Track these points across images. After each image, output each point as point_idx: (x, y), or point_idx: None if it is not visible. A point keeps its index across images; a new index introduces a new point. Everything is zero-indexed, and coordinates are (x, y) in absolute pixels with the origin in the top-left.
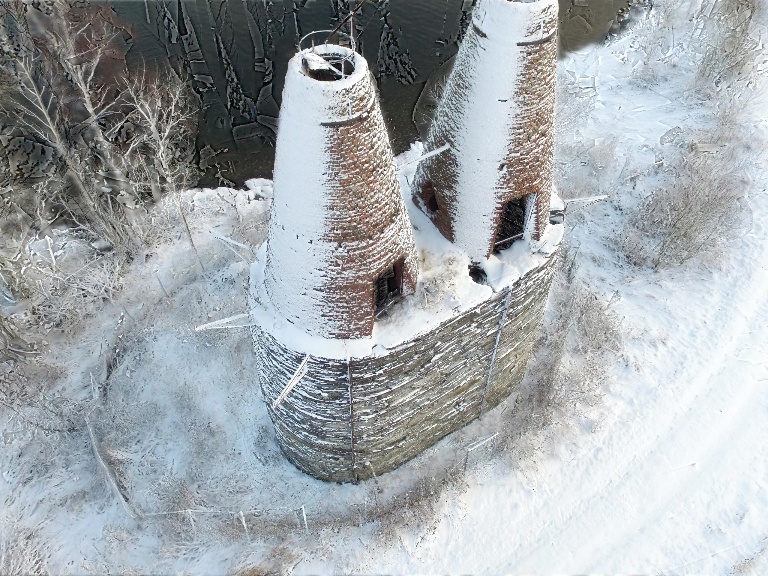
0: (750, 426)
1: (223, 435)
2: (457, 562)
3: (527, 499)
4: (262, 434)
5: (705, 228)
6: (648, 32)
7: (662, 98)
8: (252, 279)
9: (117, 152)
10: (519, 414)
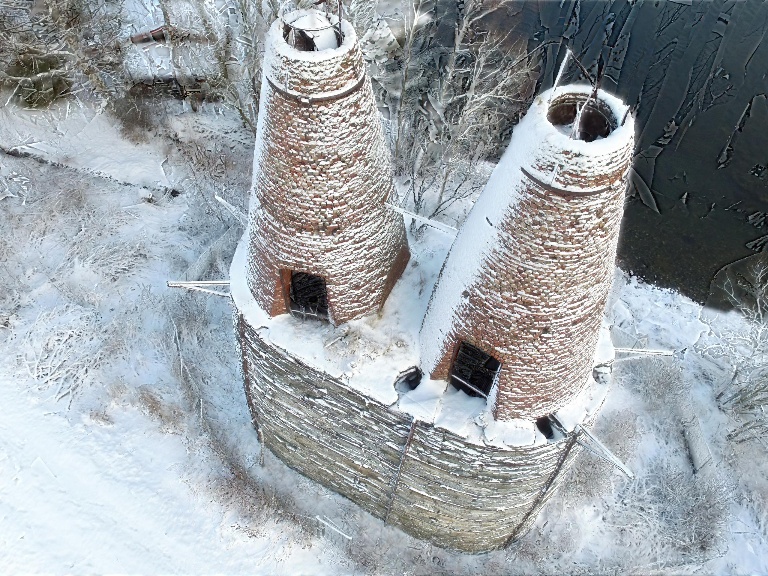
0: None
1: None
2: (235, 574)
3: None
4: None
5: None
6: None
7: None
8: None
9: (455, 90)
10: (420, 567)
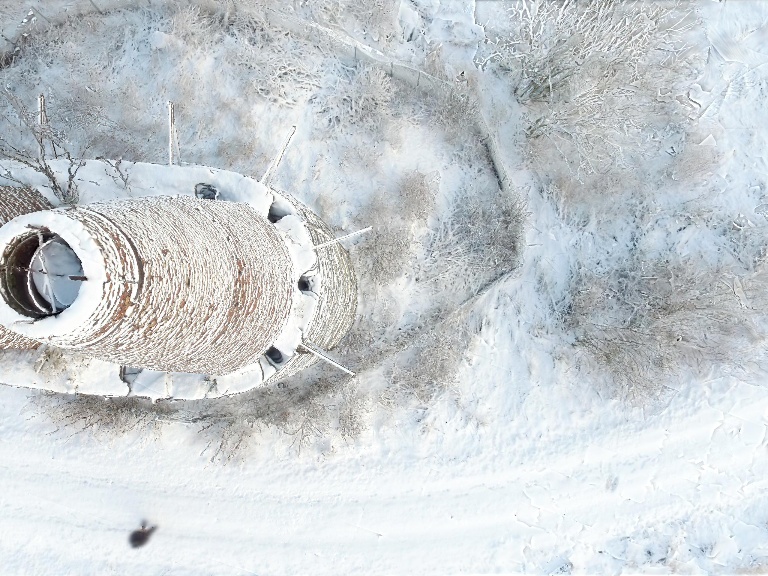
0: (461, 546)
1: None
2: (127, 462)
3: None
4: None
5: None
6: None
7: None
8: None
9: None
10: (269, 397)
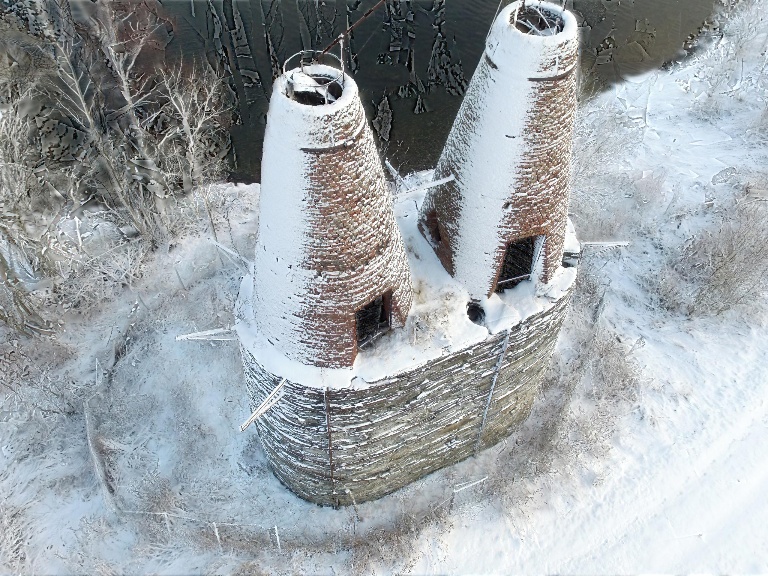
0: None
1: (214, 438)
2: None
3: (513, 548)
4: (252, 443)
5: (746, 280)
6: (715, 62)
7: (723, 133)
8: (241, 292)
9: (151, 141)
10: (517, 457)
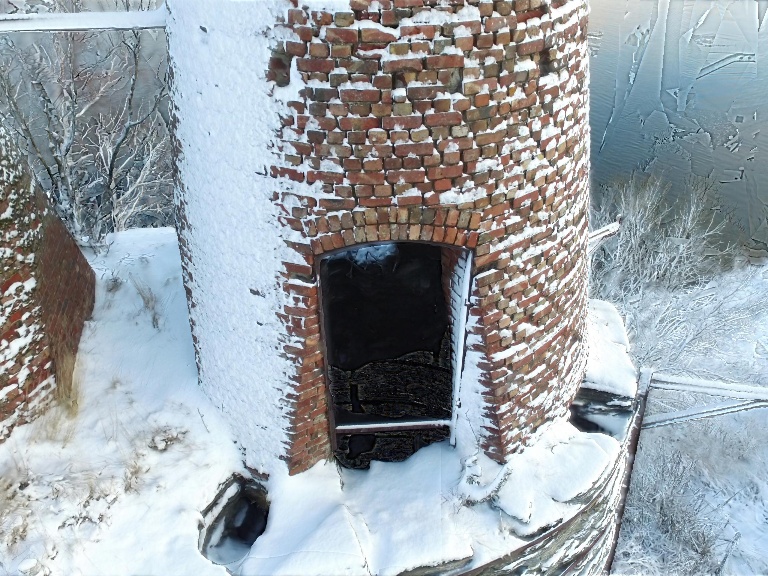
0: None
1: None
2: None
3: None
4: None
5: None
6: None
7: None
8: None
9: None
10: None
